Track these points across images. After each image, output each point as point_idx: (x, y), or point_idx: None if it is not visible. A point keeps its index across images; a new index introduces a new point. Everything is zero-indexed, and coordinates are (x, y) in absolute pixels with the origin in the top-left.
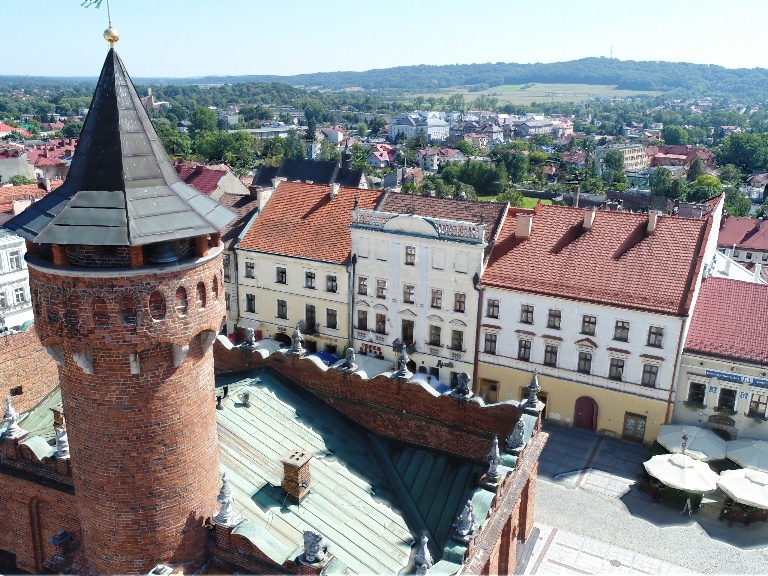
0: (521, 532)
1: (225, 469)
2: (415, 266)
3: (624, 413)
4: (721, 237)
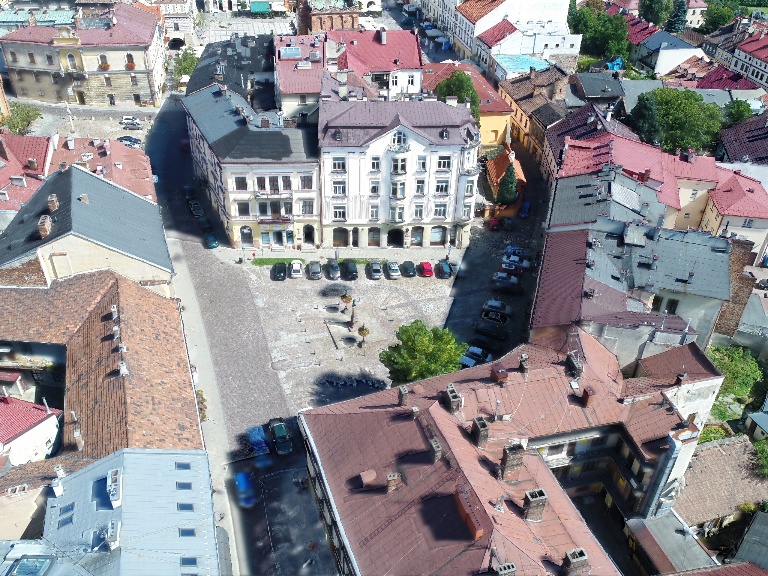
0: (353, 27)
1: (325, 6)
2: (450, 1)
3: (467, 56)
4: (762, 52)
